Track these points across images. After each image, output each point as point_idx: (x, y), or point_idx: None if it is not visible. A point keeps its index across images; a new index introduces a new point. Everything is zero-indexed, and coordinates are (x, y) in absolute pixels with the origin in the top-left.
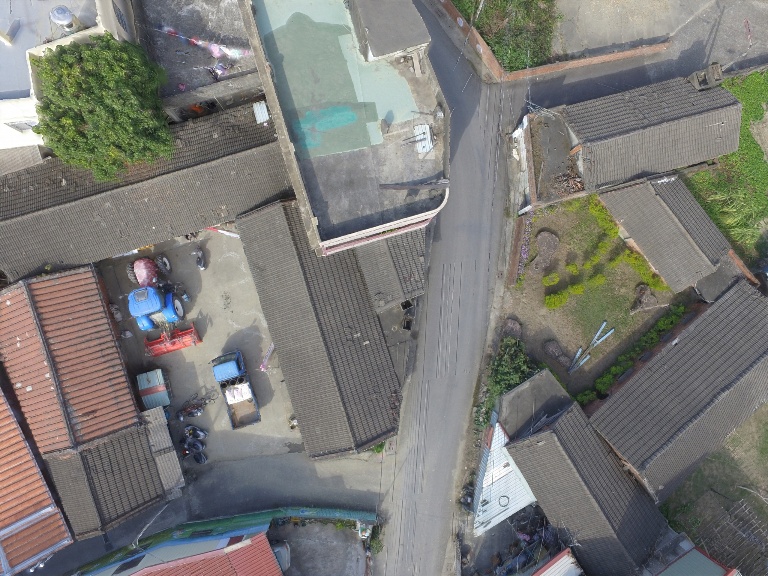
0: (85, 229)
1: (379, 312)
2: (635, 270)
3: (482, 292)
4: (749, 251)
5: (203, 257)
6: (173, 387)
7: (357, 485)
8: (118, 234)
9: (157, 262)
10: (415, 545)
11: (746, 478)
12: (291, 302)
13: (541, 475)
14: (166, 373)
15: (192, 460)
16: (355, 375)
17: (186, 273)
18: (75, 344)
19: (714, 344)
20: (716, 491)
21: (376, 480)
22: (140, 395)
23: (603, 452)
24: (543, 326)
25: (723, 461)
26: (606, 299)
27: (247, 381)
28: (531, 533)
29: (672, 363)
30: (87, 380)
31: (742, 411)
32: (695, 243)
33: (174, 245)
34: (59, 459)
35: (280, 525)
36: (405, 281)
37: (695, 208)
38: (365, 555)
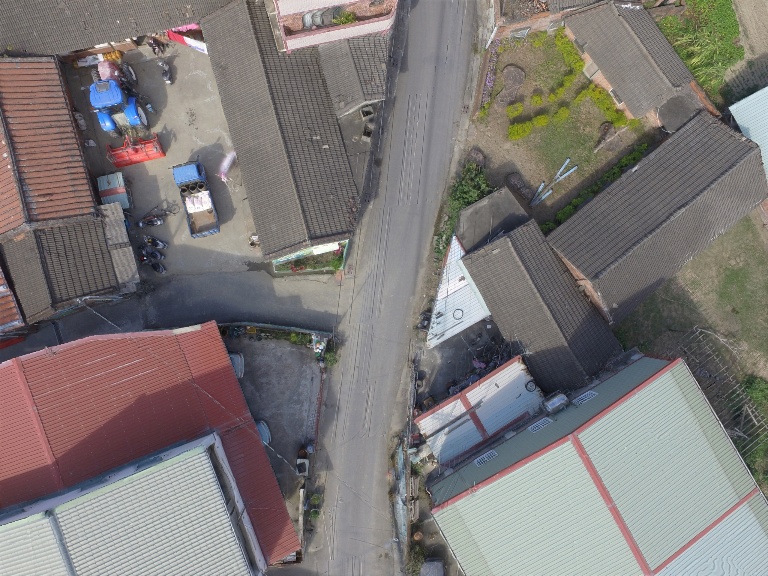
0: (49, 16)
1: (339, 115)
2: (600, 109)
3: (447, 124)
4: (714, 97)
5: (169, 72)
6: (134, 199)
7: (315, 306)
8: (82, 25)
9: (122, 67)
10: (371, 368)
11: (705, 321)
12: (251, 98)
13: (495, 286)
14: (127, 181)
15: (150, 272)
16: (312, 173)
17: (152, 88)
18: (34, 128)
19: (673, 169)
20: (674, 332)
21: (334, 302)
22: (99, 196)
23: (559, 270)
24: (506, 160)
25: (682, 303)
26: (570, 137)
27: (207, 190)
28: (487, 362)
29: (631, 187)
30: (45, 164)
31: (699, 237)
32: (656, 64)
33: (141, 59)
34: (13, 242)
35: (235, 336)
36: (365, 83)
37: (659, 37)
38: (320, 374)
